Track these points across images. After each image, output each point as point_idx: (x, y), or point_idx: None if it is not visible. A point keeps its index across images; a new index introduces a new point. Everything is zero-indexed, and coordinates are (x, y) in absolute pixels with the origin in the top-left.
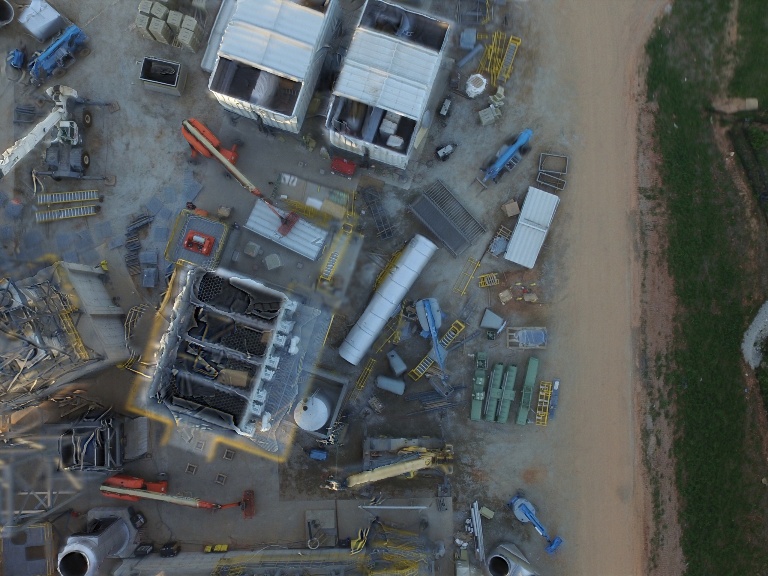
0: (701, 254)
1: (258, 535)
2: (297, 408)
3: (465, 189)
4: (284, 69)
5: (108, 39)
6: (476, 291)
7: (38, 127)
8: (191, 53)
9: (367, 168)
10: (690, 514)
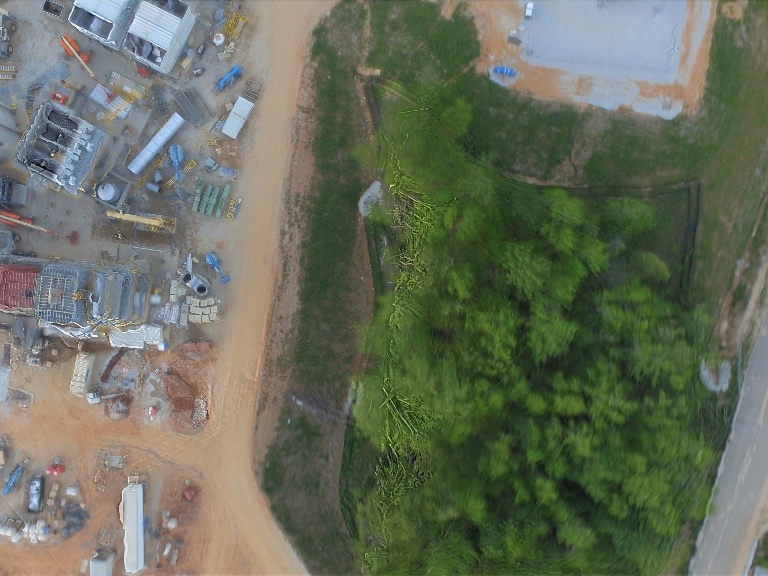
0: (337, 149)
1: (77, 255)
2: (99, 188)
3: (208, 93)
4: (105, 16)
5: None
6: (206, 147)
7: None
8: (73, 1)
9: (156, 75)
10: (306, 280)
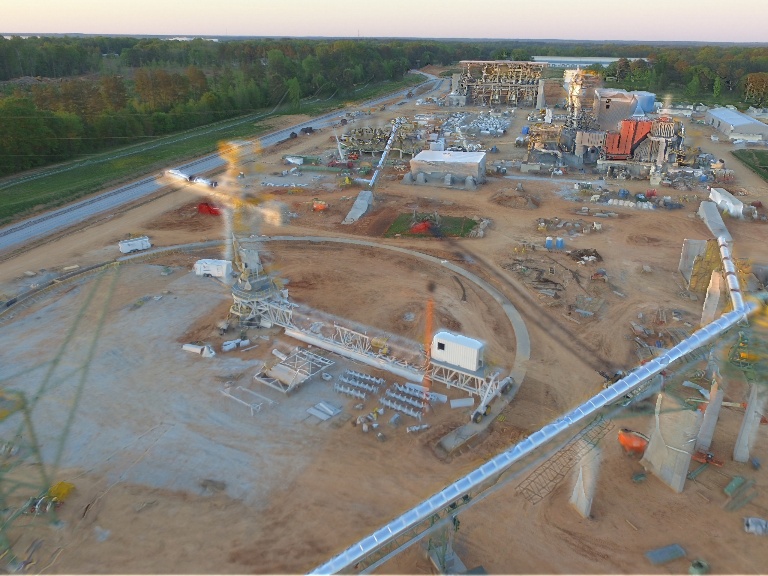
0: None
1: None
2: None
3: None
4: None
5: None
6: None
7: None
8: None
9: None
10: None
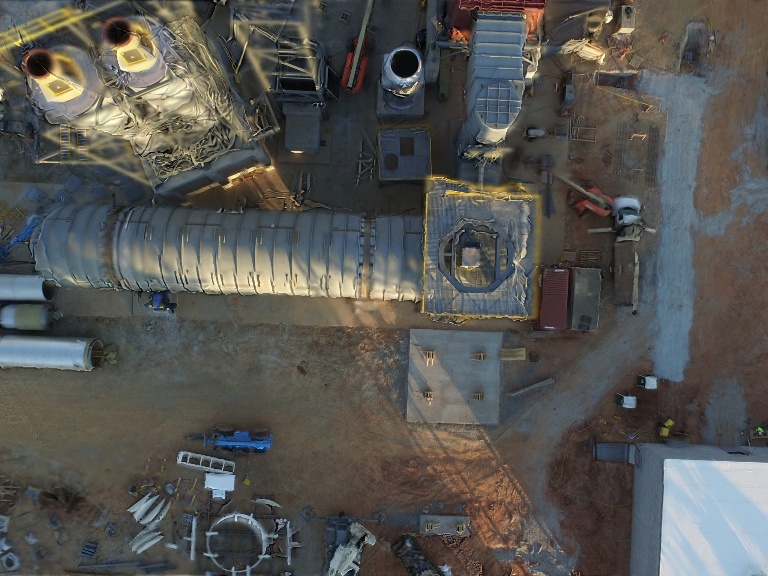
0: None
1: None
2: None
3: None
4: None
5: None
6: None
7: None
8: None
9: None
10: None
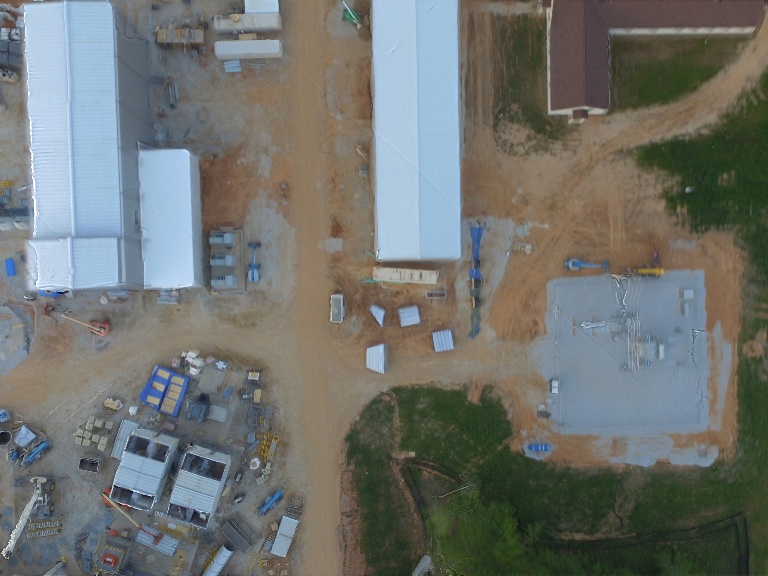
0: (384, 537)
1: None
2: None
3: (251, 516)
4: (146, 490)
5: (62, 441)
6: (257, 569)
7: (27, 510)
8: (106, 449)
9: None
10: None
